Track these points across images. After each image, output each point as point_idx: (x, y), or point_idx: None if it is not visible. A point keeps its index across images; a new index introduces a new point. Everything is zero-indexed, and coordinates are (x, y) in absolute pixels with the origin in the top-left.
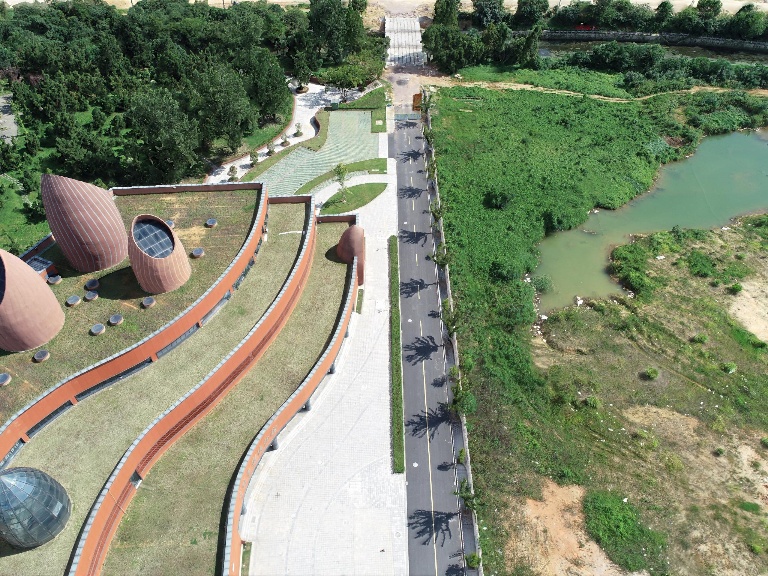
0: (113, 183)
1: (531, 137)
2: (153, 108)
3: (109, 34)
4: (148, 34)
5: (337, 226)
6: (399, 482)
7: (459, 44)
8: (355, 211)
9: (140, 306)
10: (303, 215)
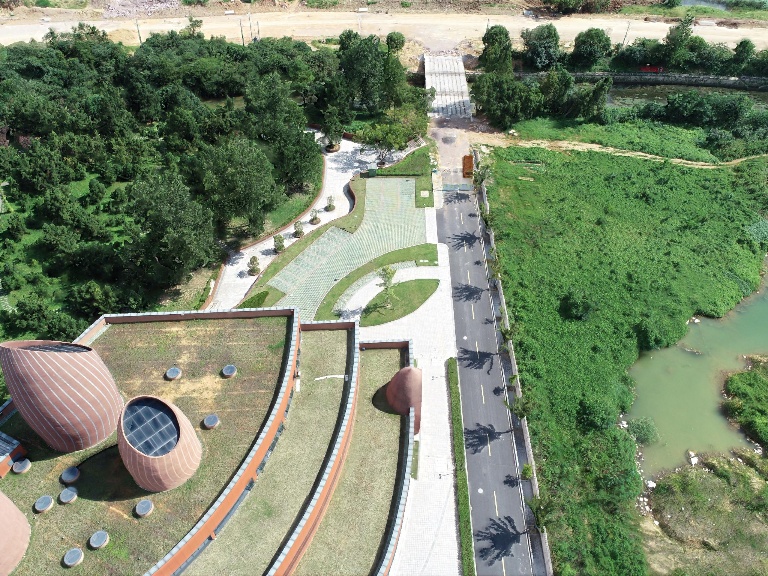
0: (109, 288)
1: (607, 216)
2: (158, 201)
3: (112, 87)
4: (158, 78)
5: (385, 355)
6: None
7: (515, 96)
8: (402, 320)
9: (132, 514)
10: (344, 349)
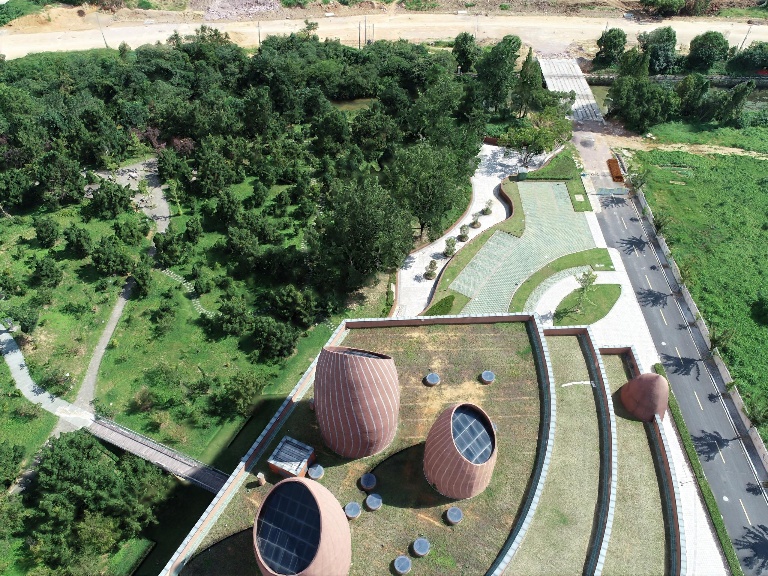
0: (310, 292)
1: None
2: (371, 206)
3: None
4: None
5: (607, 361)
6: None
7: (654, 99)
8: (596, 325)
9: (444, 521)
10: (581, 355)
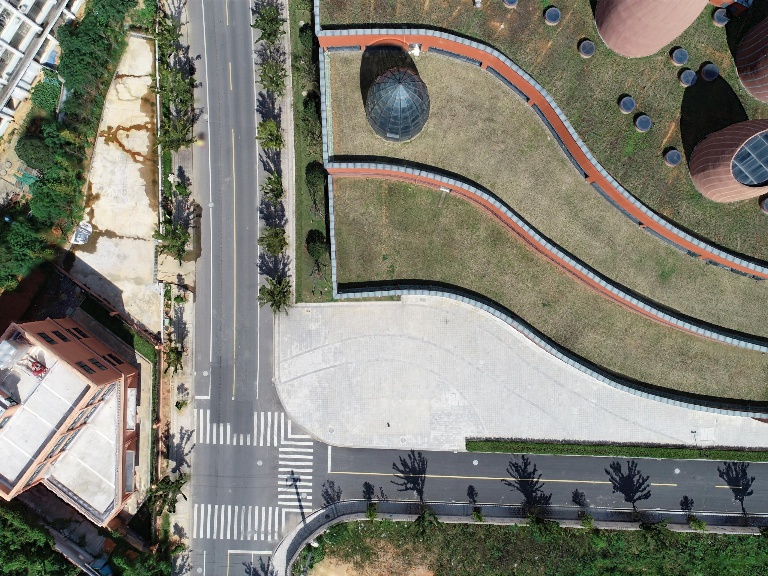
0: None
1: None
2: None
3: None
4: None
5: None
6: (457, 445)
7: None
8: None
9: (667, 147)
10: None
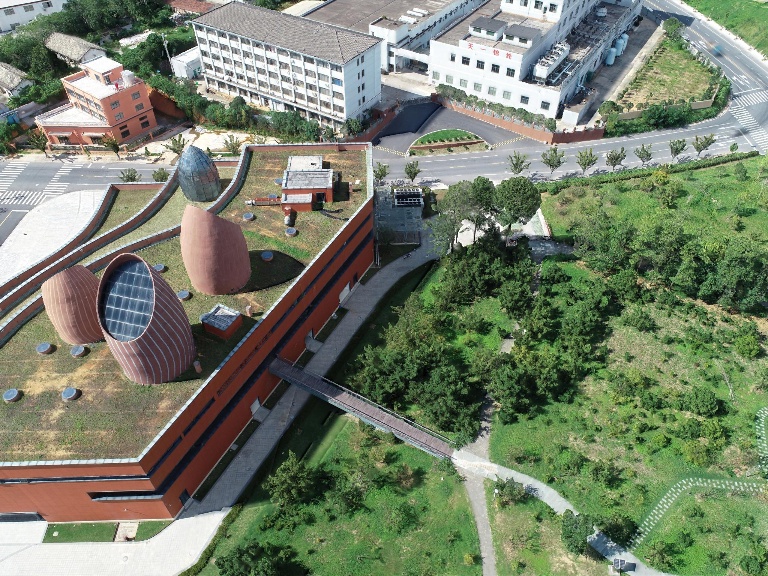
0: None
1: None
2: None
3: None
4: None
5: None
6: None
7: None
8: None
9: None
10: None
